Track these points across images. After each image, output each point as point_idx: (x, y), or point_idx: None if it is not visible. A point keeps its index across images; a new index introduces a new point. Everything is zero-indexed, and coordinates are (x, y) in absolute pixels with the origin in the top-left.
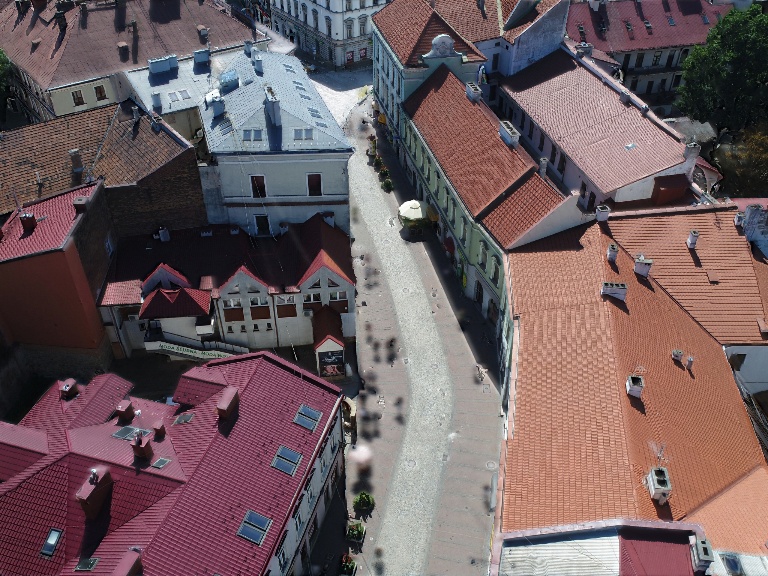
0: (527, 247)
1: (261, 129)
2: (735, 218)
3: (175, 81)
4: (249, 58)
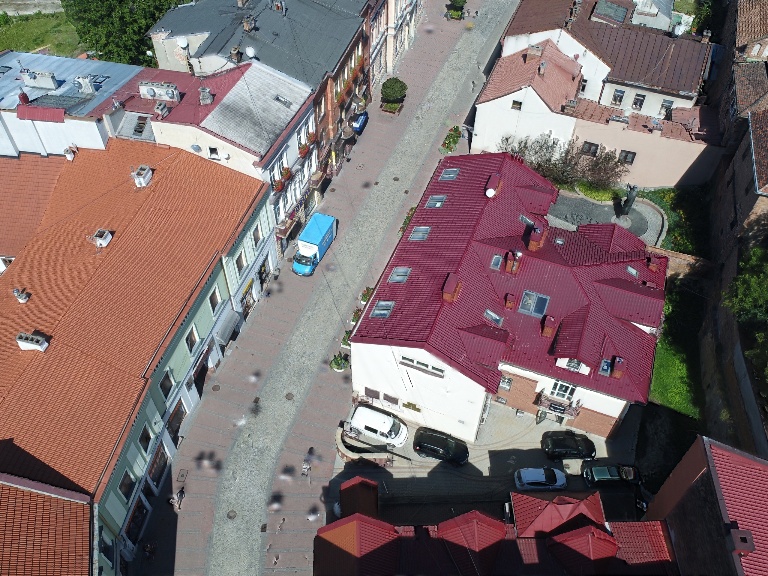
0: None
1: None
2: None
3: None
4: None
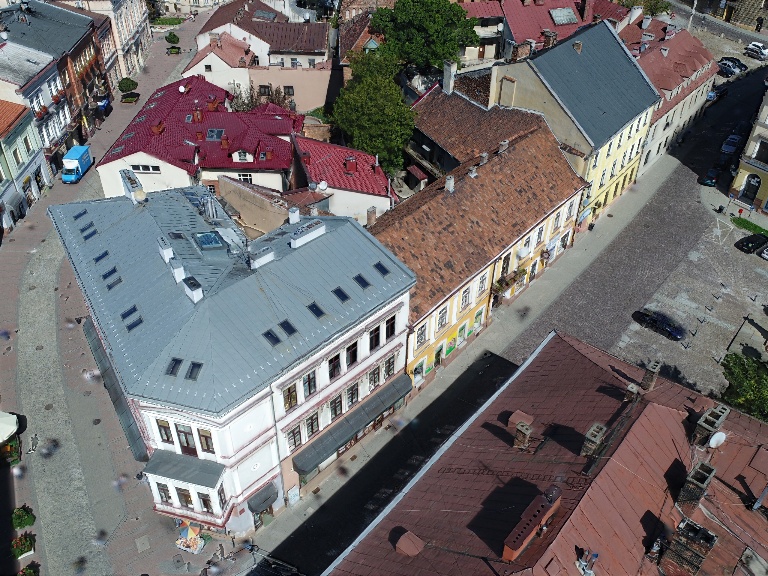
0: None
1: (151, 193)
2: None
3: (289, 241)
4: None
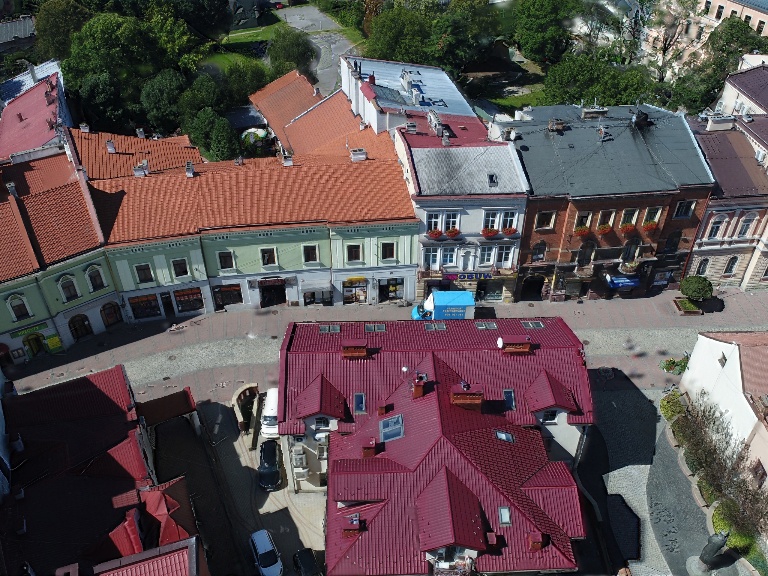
0: (105, 228)
1: None
2: (83, 130)
3: None
4: None
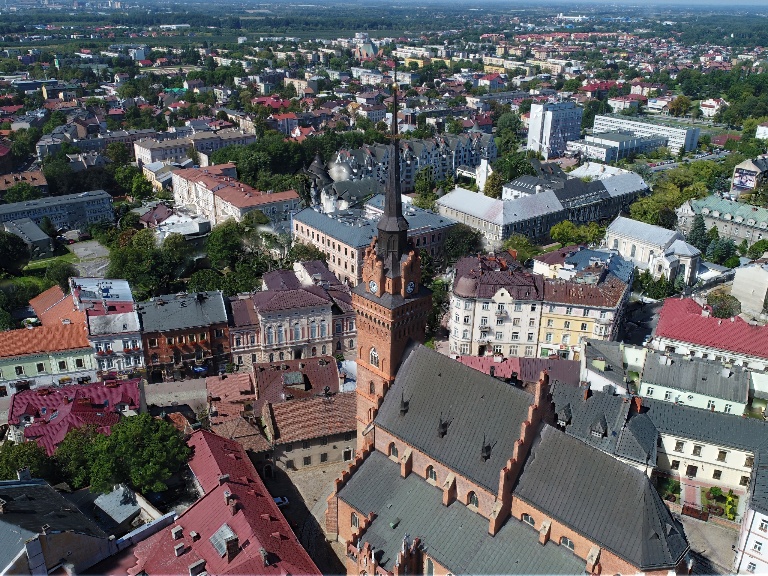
0: None
1: None
2: None
3: None
4: None
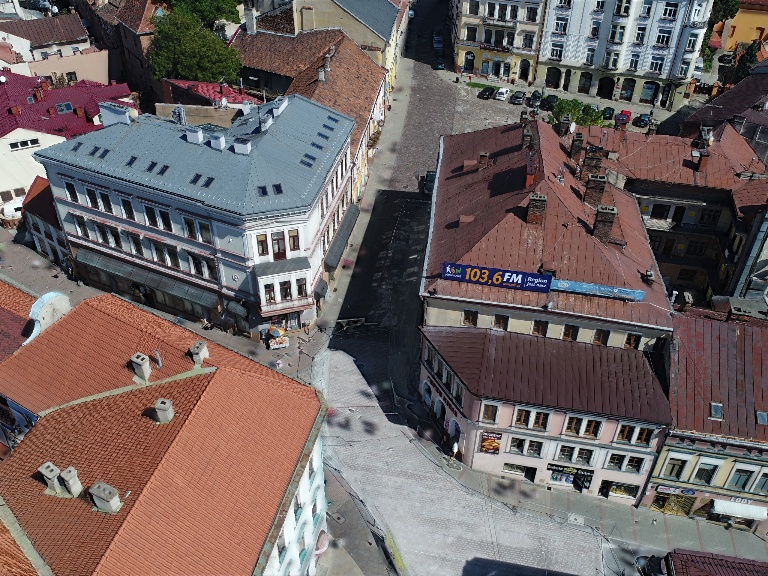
0: None
1: None
2: None
3: None
4: (230, 145)
